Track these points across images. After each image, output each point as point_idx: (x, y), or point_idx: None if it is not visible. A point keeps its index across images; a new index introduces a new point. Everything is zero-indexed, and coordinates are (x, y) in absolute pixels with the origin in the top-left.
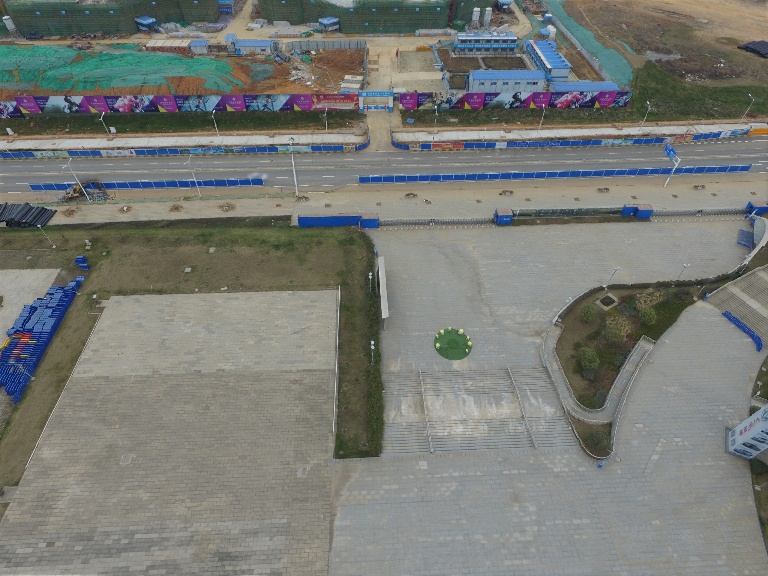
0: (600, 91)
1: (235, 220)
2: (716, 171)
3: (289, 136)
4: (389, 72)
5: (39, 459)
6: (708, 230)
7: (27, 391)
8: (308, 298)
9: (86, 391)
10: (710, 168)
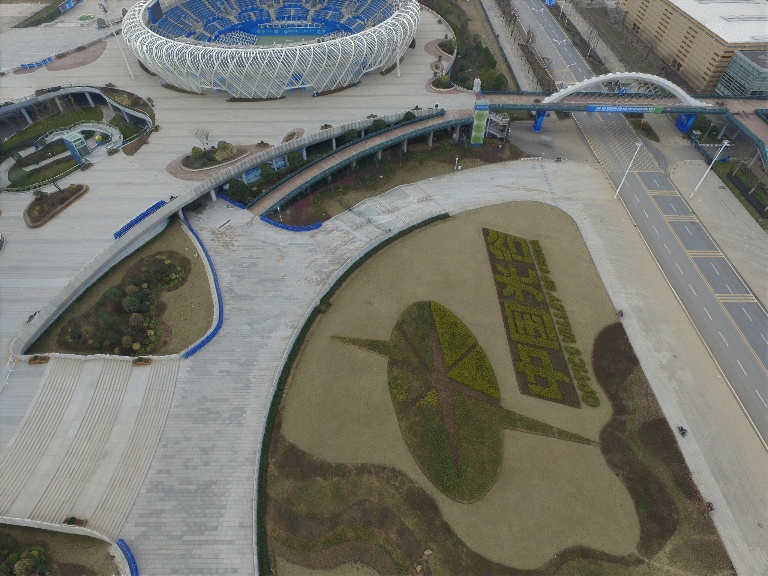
0: None
1: None
2: None
3: None
4: None
5: None
6: None
7: None
8: None
9: None
10: None
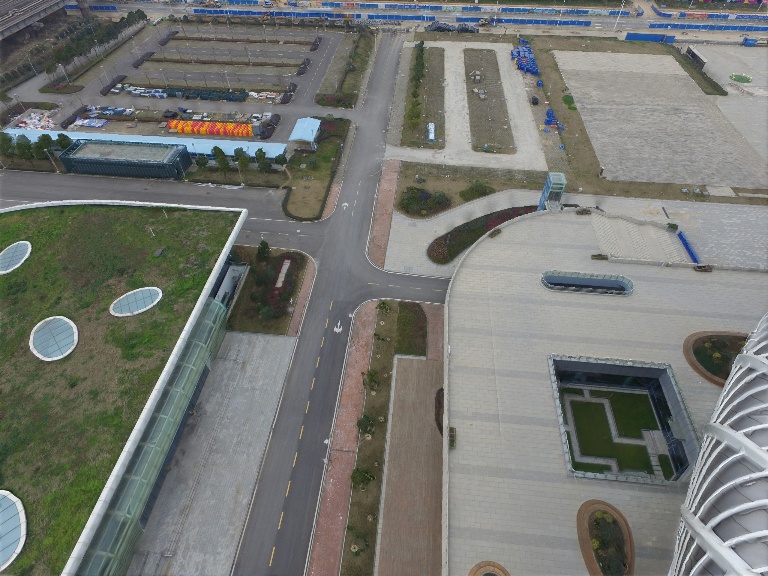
0: None
1: None
2: None
3: (587, 9)
4: None
5: (571, 85)
6: None
7: (540, 73)
8: (658, 56)
9: (572, 72)
10: None
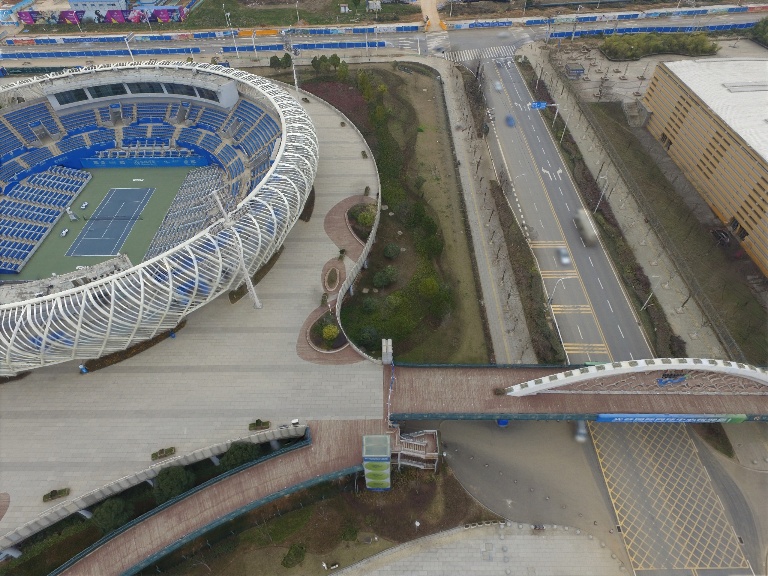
0: (155, 9)
1: None
2: (178, 52)
3: None
4: (47, 4)
5: None
6: None
7: None
8: None
9: None
10: (172, 50)
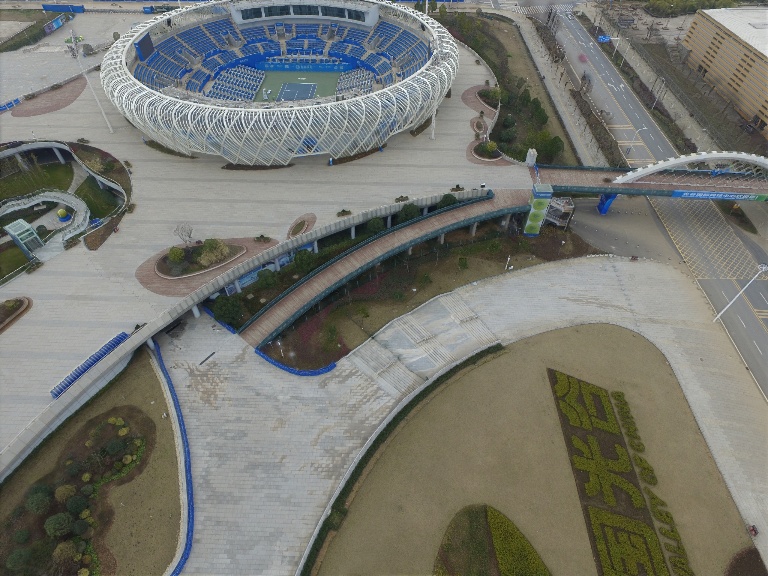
0: None
1: (15, 9)
2: None
3: None
4: None
5: None
6: None
7: None
8: (18, 23)
9: None
10: None
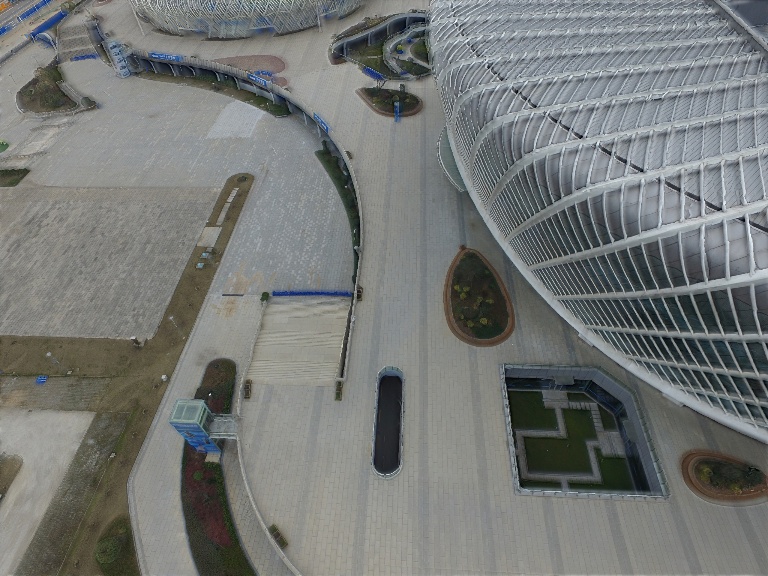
0: None
1: None
2: None
3: None
4: None
5: None
6: (27, 54)
7: None
8: None
9: None
10: None
